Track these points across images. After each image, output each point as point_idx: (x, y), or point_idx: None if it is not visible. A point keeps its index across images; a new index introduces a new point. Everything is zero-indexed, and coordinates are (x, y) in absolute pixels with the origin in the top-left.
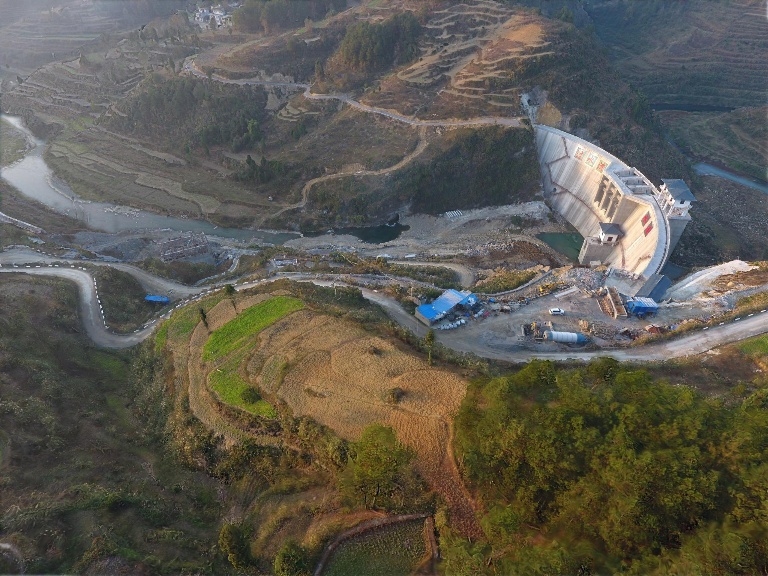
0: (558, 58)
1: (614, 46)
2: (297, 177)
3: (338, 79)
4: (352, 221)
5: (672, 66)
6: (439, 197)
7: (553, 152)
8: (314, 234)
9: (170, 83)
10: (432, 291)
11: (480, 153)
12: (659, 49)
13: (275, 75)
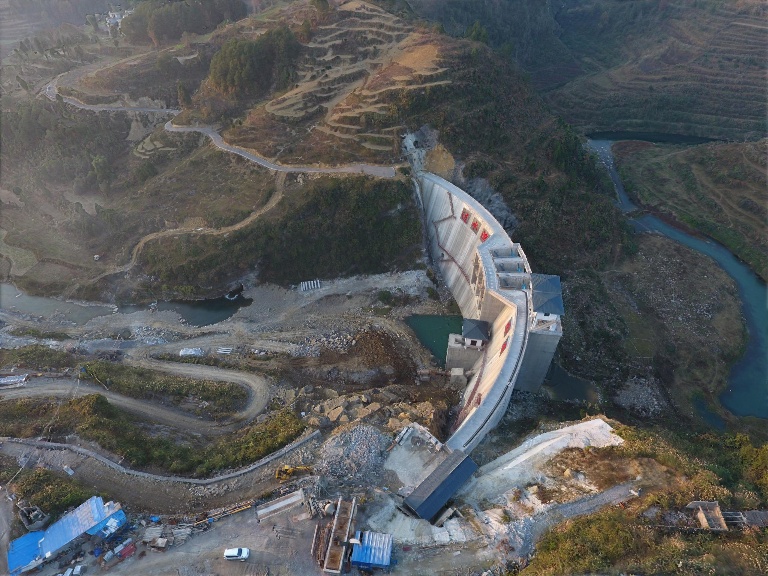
0: (455, 89)
1: (585, 57)
2: (132, 231)
3: (203, 107)
4: (181, 293)
5: (638, 86)
6: (293, 263)
7: (440, 209)
8: (132, 308)
9: (19, 108)
10: (69, 498)
11: (343, 210)
12: (629, 64)
13: (142, 99)
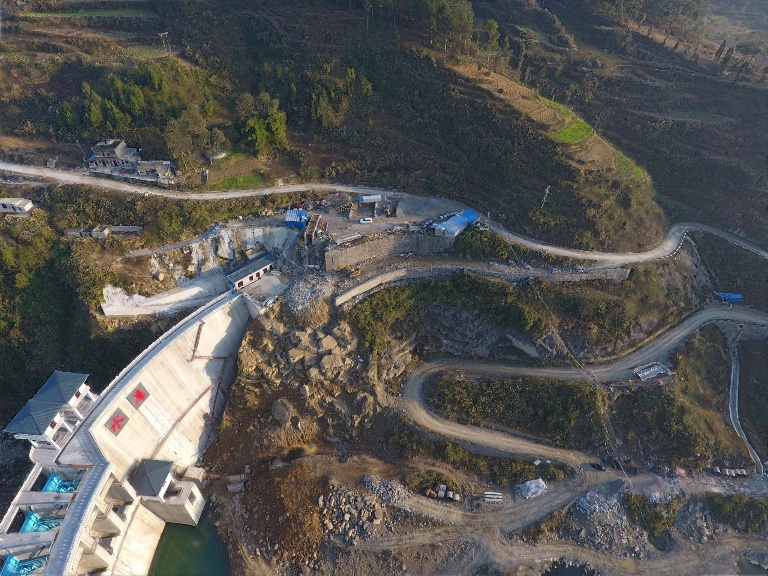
0: None
1: None
2: None
3: None
4: None
5: None
6: None
7: None
8: None
9: None
10: (468, 234)
11: None
12: None
13: None
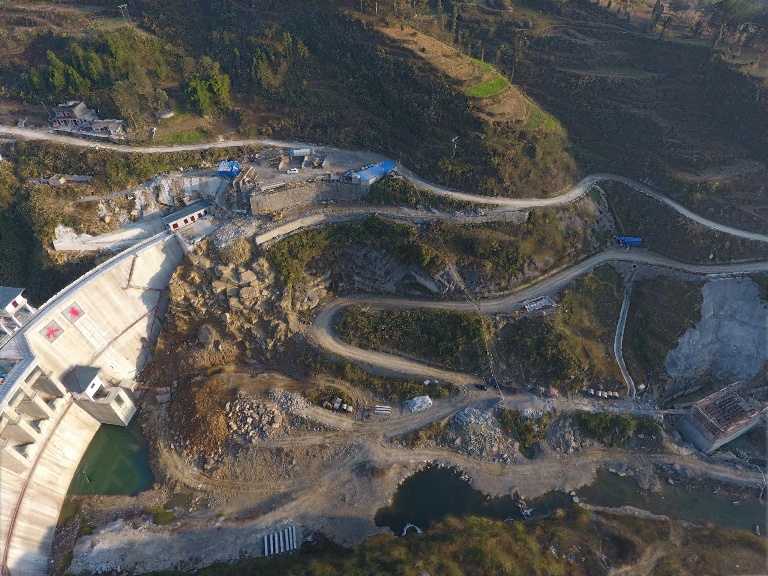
0: None
1: None
2: None
3: None
4: None
5: None
6: None
7: None
8: (555, 504)
9: None
10: (382, 181)
11: None
12: None
13: None
